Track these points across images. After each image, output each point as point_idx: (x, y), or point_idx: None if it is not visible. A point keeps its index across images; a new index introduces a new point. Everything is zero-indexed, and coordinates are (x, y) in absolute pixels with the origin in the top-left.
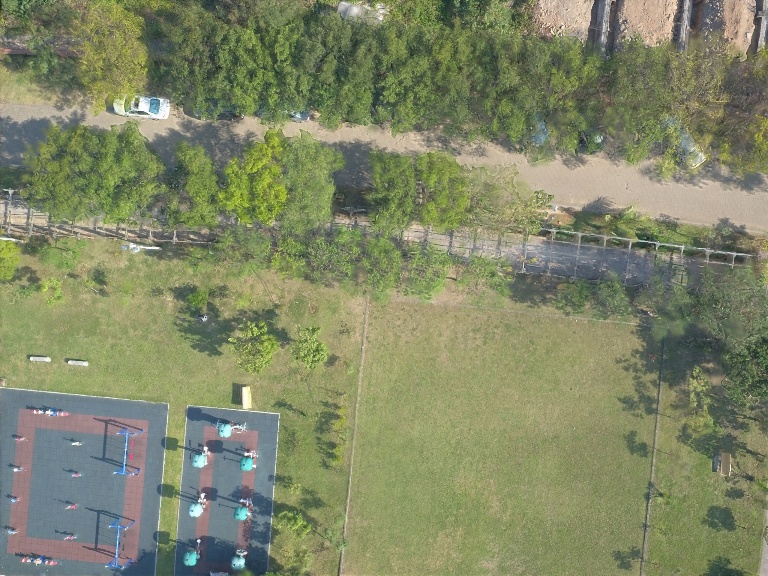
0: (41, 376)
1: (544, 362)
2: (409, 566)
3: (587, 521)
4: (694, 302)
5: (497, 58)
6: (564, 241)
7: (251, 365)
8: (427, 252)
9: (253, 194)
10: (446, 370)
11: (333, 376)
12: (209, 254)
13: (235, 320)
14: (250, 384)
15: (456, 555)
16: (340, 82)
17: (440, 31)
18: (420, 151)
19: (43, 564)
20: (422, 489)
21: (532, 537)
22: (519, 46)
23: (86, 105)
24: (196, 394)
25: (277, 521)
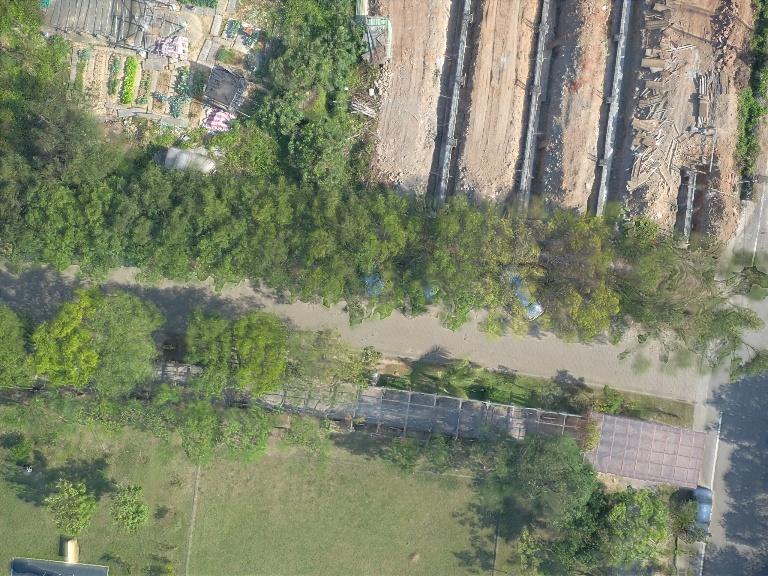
0: None
1: (380, 515)
2: None
3: None
4: (513, 475)
5: (317, 220)
6: None
7: (69, 526)
8: (260, 403)
9: (63, 358)
10: (280, 523)
11: (164, 528)
12: (37, 401)
13: (63, 469)
14: (78, 536)
15: None
16: (155, 242)
17: (264, 187)
18: (255, 298)
19: None
20: None
21: None
22: (338, 210)
23: None
24: (22, 545)
25: None
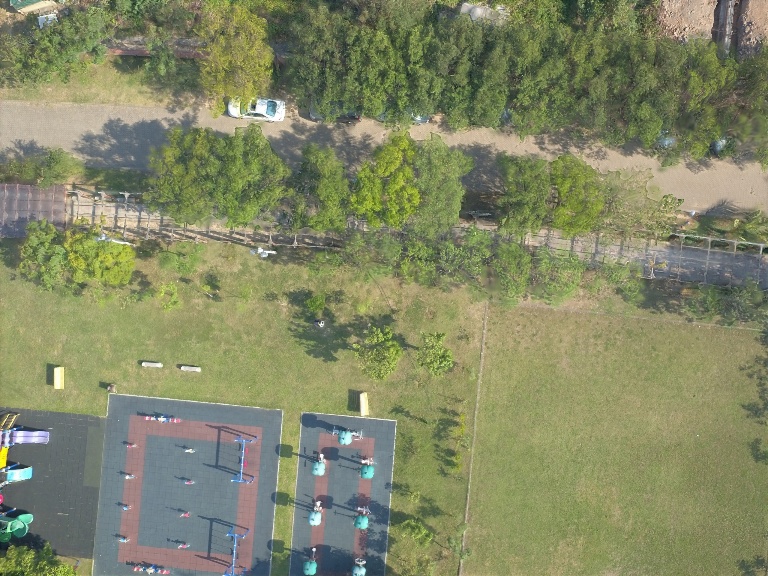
0: (152, 382)
1: (667, 368)
2: (529, 575)
3: (711, 530)
4: None
5: (633, 60)
6: (691, 246)
7: (375, 371)
8: (549, 257)
9: (385, 198)
10: (567, 376)
11: (451, 382)
12: (325, 258)
13: (351, 325)
14: (366, 390)
15: (577, 564)
16: (473, 84)
17: None
18: (540, 154)
19: (155, 573)
20: (542, 497)
21: (655, 546)
22: (658, 48)
23: (198, 107)
24: (311, 400)
25: (394, 529)
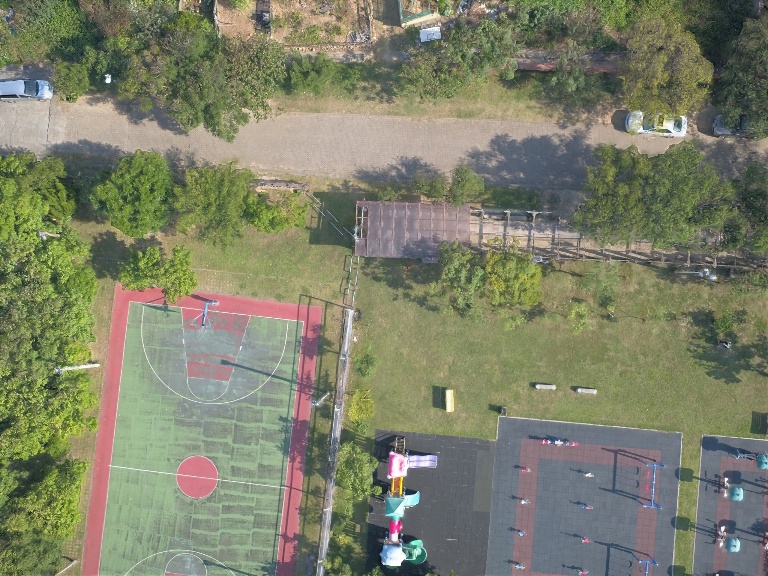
0: (545, 404)
1: None
2: None
3: None
4: None
5: None
6: None
7: None
8: None
9: None
10: None
11: None
12: (728, 277)
13: (754, 346)
14: None
15: None
16: None
17: None
18: None
19: None
20: None
21: None
22: None
23: (591, 122)
24: (712, 423)
25: None
